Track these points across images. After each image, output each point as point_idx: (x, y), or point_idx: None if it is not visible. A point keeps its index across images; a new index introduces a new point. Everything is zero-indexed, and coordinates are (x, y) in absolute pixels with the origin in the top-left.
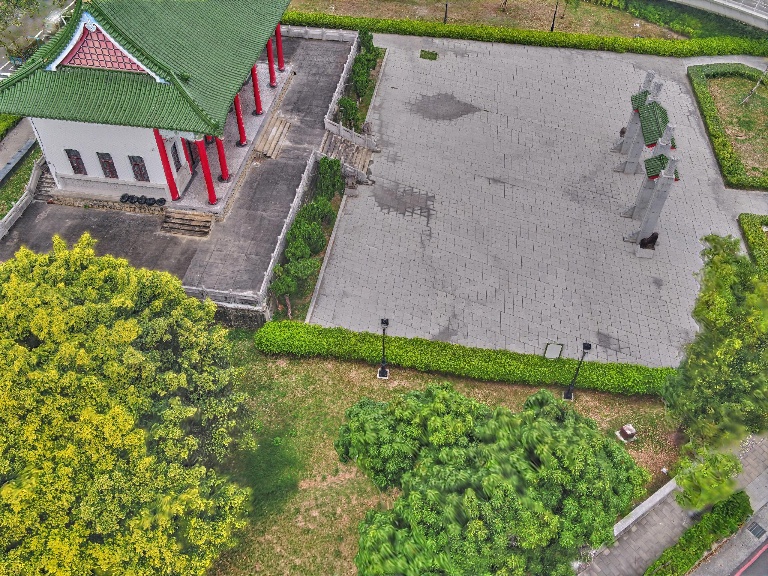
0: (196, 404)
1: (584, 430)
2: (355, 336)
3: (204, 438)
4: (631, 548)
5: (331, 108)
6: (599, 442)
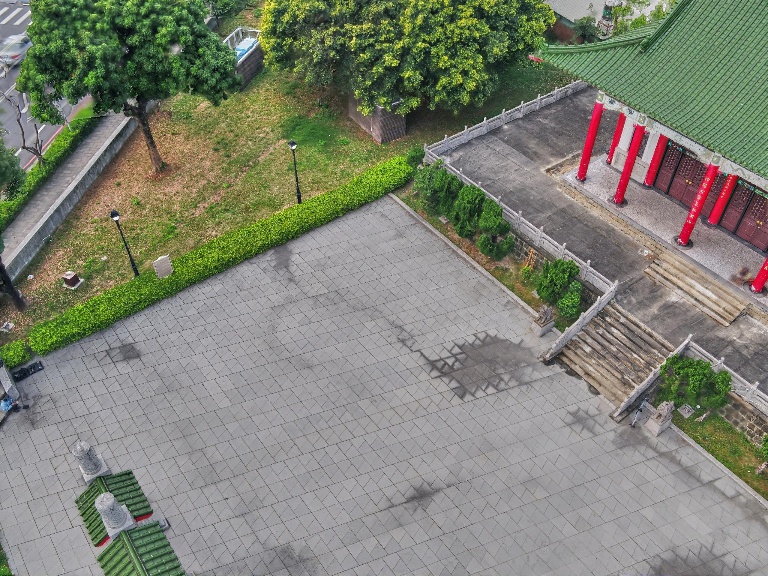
0: (325, 30)
1: (51, 1)
2: (343, 200)
3: (308, 36)
4: (44, 208)
5: (719, 363)
6: (40, 4)
